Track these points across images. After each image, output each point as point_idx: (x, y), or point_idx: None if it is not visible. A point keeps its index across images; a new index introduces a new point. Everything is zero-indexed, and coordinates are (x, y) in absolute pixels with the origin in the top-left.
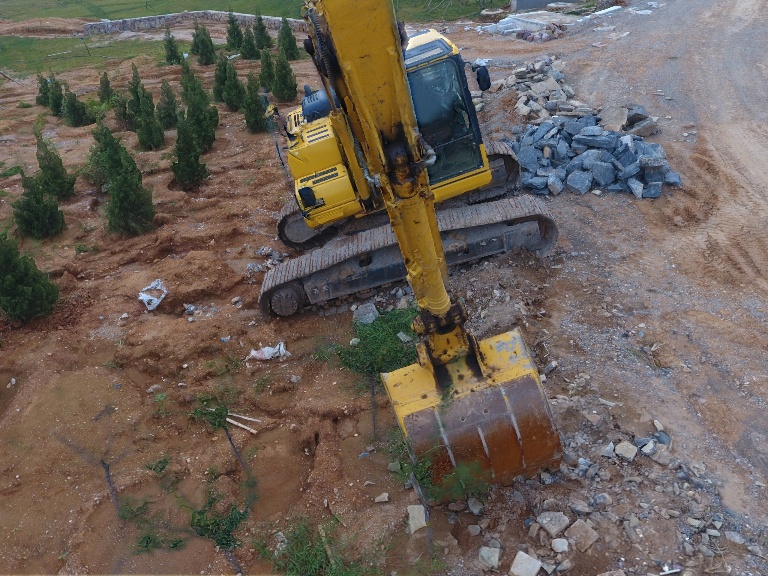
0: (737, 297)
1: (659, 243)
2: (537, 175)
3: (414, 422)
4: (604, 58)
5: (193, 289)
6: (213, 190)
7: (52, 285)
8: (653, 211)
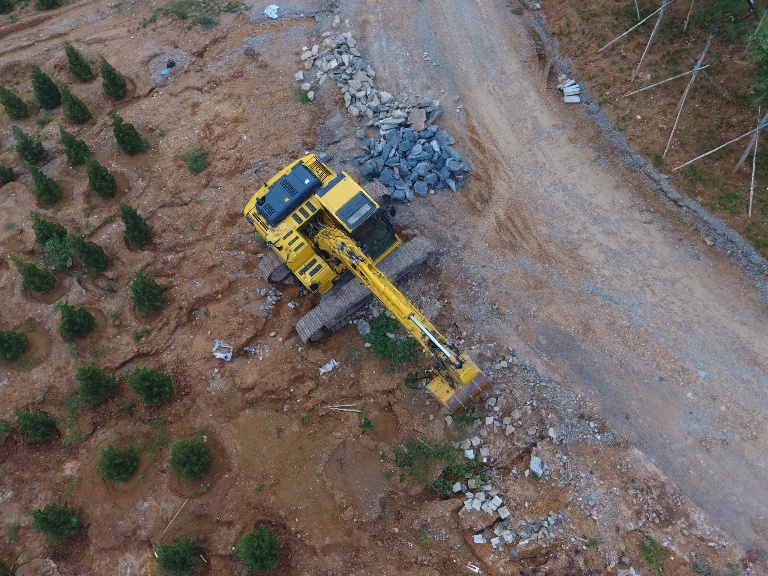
0: (518, 258)
1: (476, 229)
2: (397, 189)
3: (450, 403)
4: (373, 8)
5: (246, 339)
6: (170, 243)
7: (167, 376)
8: (465, 200)
